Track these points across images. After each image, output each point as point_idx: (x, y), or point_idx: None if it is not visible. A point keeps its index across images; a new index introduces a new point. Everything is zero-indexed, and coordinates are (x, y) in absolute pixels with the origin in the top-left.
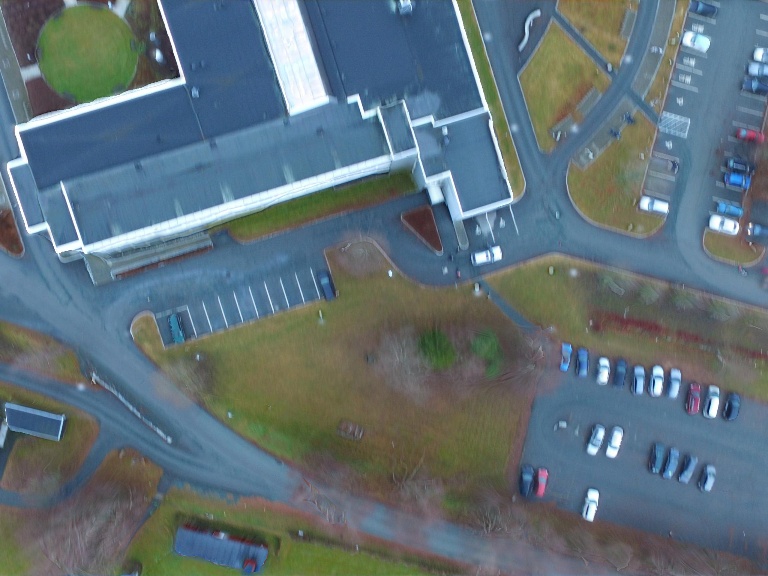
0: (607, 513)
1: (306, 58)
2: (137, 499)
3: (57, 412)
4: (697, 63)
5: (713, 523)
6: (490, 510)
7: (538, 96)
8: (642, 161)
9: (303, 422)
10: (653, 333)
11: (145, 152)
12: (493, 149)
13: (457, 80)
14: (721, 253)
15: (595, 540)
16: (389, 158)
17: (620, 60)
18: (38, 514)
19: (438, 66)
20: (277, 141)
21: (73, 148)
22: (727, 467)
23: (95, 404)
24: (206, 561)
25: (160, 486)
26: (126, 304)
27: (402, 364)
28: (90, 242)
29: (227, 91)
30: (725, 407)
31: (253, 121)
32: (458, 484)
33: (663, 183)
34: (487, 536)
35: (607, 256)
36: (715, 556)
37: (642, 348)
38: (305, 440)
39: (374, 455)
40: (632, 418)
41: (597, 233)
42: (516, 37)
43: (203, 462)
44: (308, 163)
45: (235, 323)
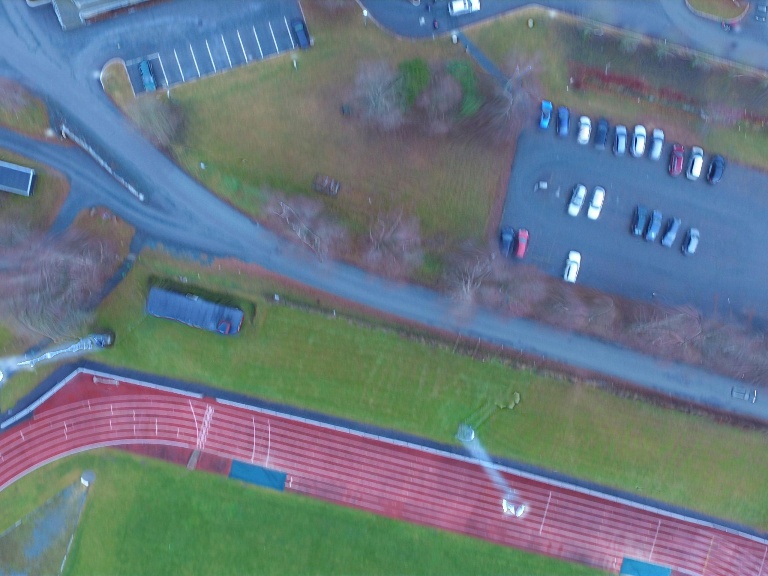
0: (589, 275)
1: None
2: (108, 254)
3: (26, 166)
4: None
5: (697, 288)
6: (469, 264)
7: None
8: None
9: (278, 176)
10: (635, 92)
11: None
12: None
13: None
14: (704, 8)
15: (576, 296)
16: None
17: None
18: (8, 276)
19: None
20: None
21: None
22: (711, 231)
23: (65, 161)
24: (180, 329)
25: (132, 246)
26: (96, 51)
27: (378, 107)
28: None
29: None
30: (709, 169)
31: None
32: (437, 245)
33: None
34: (467, 299)
35: (587, 9)
36: (699, 316)
37: (624, 108)
38: (280, 196)
39: (350, 212)
40: (614, 180)
41: None
42: None
43: (176, 220)
44: None
45: (207, 72)
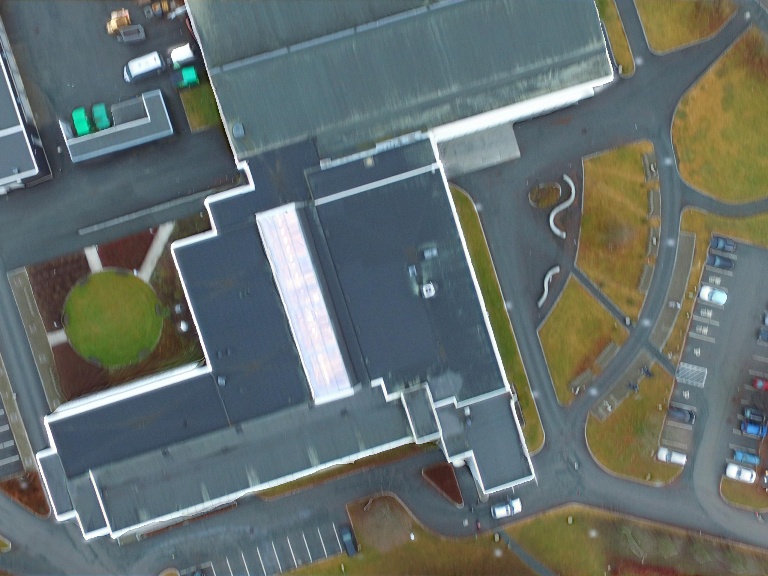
0: None
1: (331, 350)
2: None
3: None
4: (714, 314)
5: None
6: None
7: (557, 351)
8: (660, 412)
9: None
10: None
11: (172, 439)
12: (515, 427)
13: (479, 361)
14: (738, 499)
15: None
16: (412, 440)
17: (638, 313)
18: None
19: (460, 347)
20: (302, 423)
21: (101, 436)
22: None
23: None
24: None
25: None
26: (151, 561)
27: None
28: (118, 528)
29: (253, 377)
30: None
31: (278, 406)
32: None
33: (680, 432)
34: None
35: (625, 505)
36: None
37: None
38: None
39: None
40: None
41: (615, 483)
42: (535, 293)
43: None
44: (332, 445)
45: None
